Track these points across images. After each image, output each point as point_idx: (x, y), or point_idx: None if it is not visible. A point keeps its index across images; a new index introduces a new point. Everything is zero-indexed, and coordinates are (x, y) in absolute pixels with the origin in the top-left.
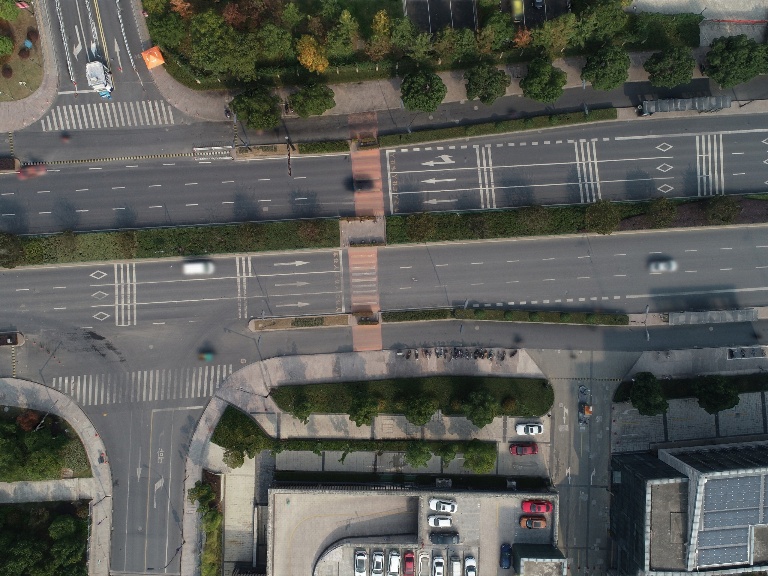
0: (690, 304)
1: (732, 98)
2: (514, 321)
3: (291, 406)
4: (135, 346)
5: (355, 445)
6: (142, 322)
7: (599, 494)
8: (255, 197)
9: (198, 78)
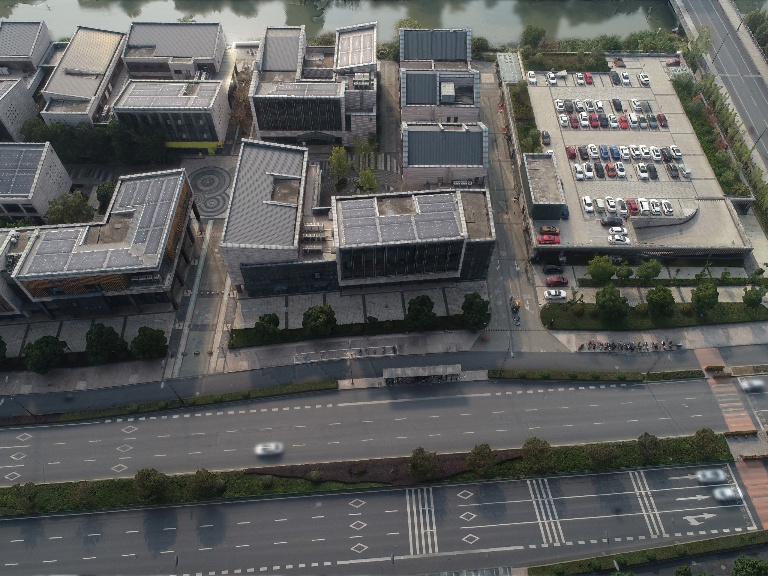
0: (432, 389)
1: None
2: None
3: None
4: None
5: (692, 282)
6: None
7: None
8: None
9: None
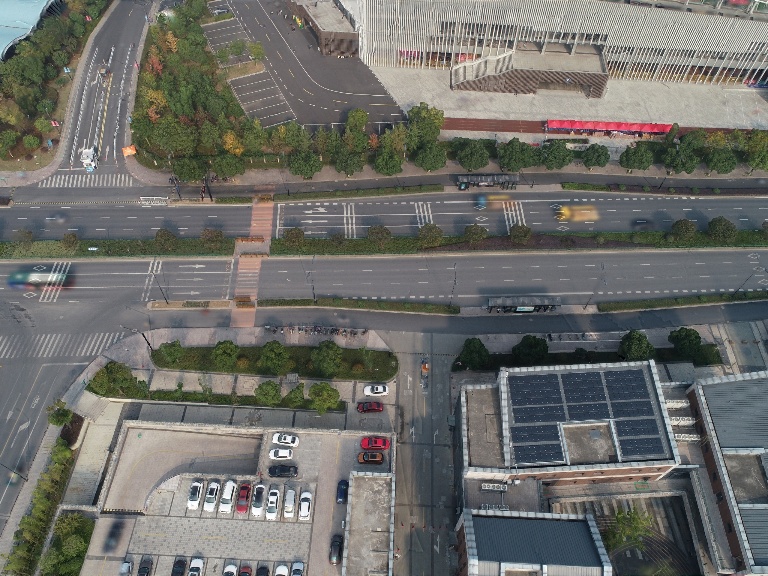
0: None
1: (525, 184)
2: (366, 310)
3: (165, 363)
4: (48, 316)
5: (215, 398)
6: (61, 300)
7: (442, 452)
8: (176, 226)
9: (156, 159)
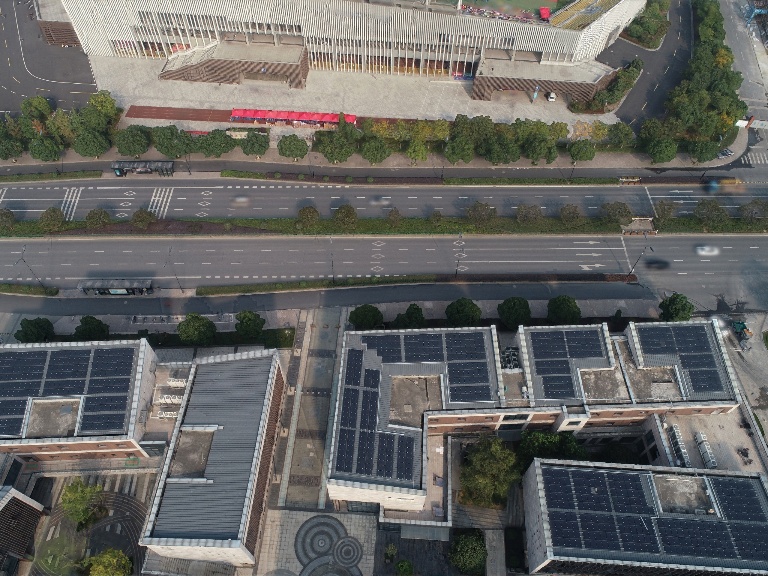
0: None
1: (187, 171)
2: None
3: None
4: None
5: None
6: None
7: None
8: None
9: None
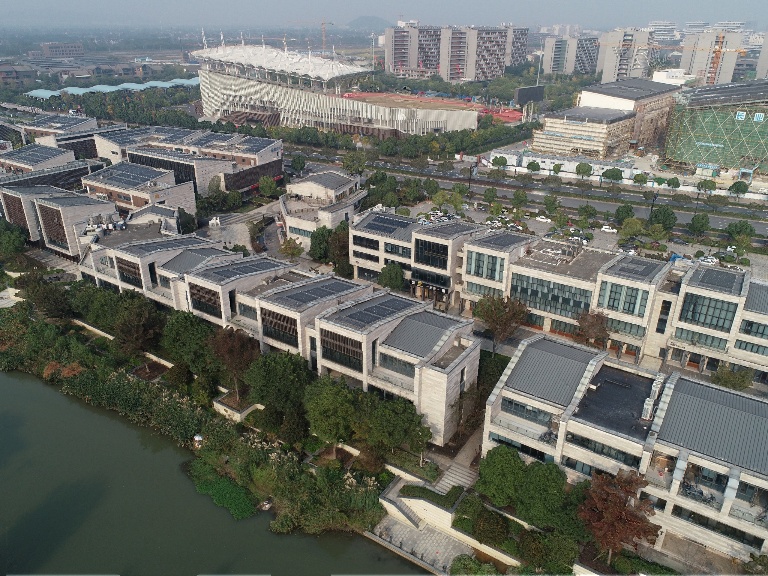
0: None
1: None
2: None
3: None
4: None
5: None
6: None
7: None
8: None
9: None
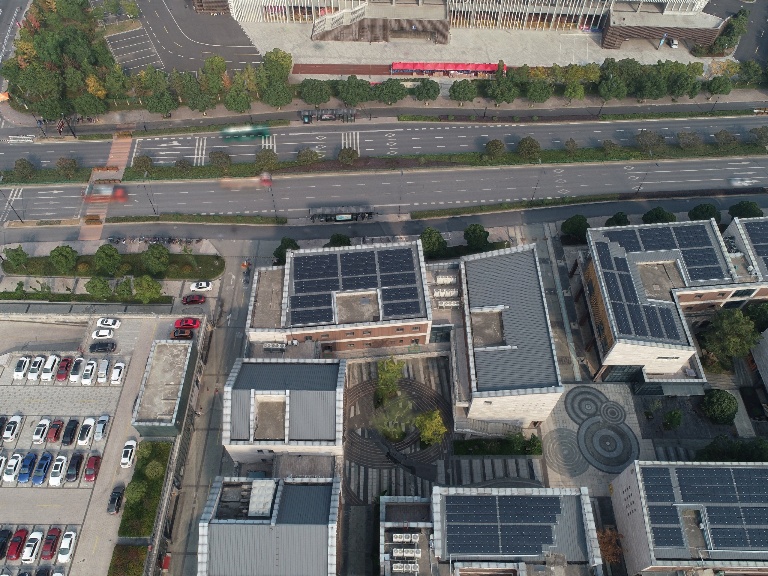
0: None
1: (365, 117)
2: (203, 223)
3: (14, 269)
4: None
5: (55, 296)
6: None
7: None
8: (40, 160)
9: None
